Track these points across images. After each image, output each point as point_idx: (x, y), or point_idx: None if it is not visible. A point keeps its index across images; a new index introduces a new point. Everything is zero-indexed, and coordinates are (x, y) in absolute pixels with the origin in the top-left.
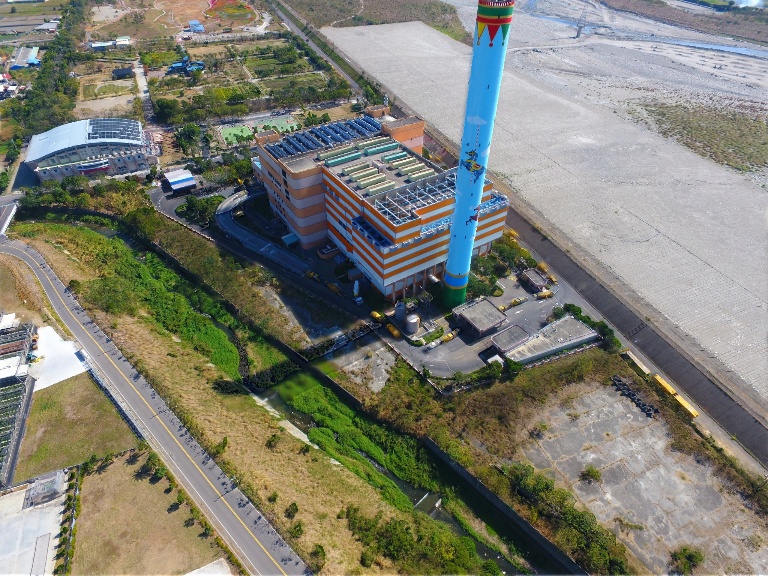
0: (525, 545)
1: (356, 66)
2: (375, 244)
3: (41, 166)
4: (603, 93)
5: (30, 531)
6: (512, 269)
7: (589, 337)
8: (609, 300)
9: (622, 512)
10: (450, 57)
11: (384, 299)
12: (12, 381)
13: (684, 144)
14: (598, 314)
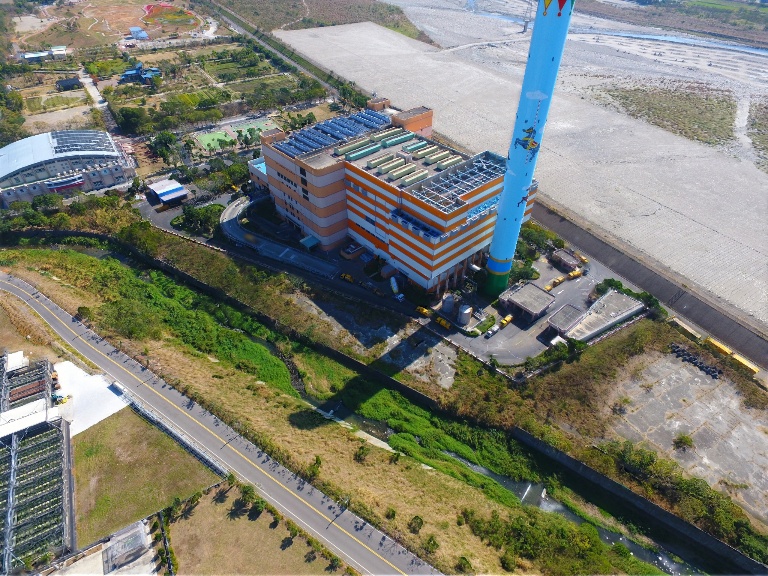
0: (643, 522)
1: (321, 66)
2: (424, 235)
3: (3, 186)
4: (566, 81)
5: None
6: (540, 252)
7: (638, 309)
8: (642, 272)
9: (723, 474)
10: (411, 54)
11: (426, 293)
12: (43, 428)
13: (654, 123)
14: (634, 286)
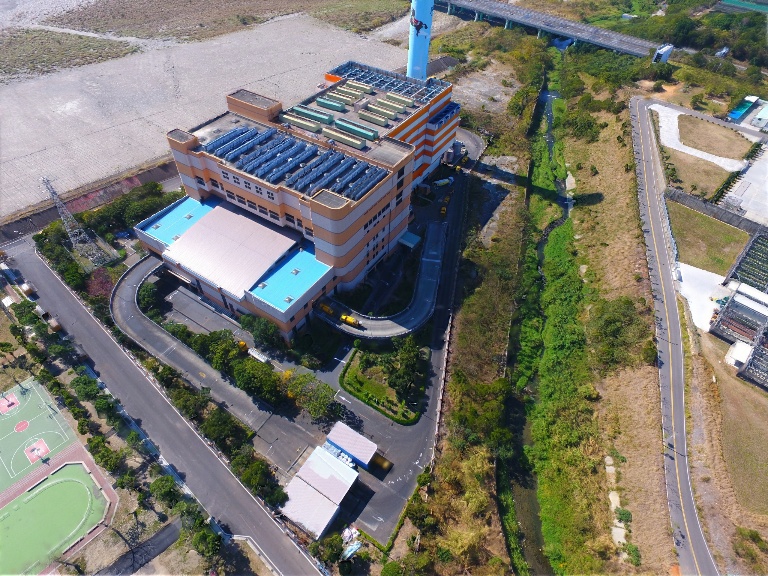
0: None
1: None
2: None
3: None
4: None
5: (744, 201)
6: None
7: None
8: None
9: (501, 94)
10: None
11: None
12: None
13: (78, 65)
14: None
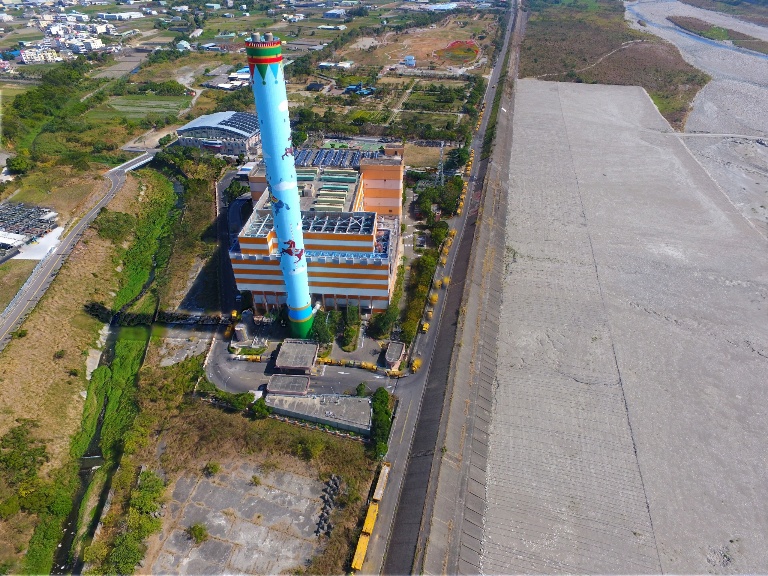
0: None
1: (507, 117)
2: None
3: (184, 135)
4: None
5: None
6: (393, 336)
7: (358, 427)
8: (435, 410)
9: None
10: (624, 127)
11: (253, 305)
12: None
13: None
14: (415, 418)
